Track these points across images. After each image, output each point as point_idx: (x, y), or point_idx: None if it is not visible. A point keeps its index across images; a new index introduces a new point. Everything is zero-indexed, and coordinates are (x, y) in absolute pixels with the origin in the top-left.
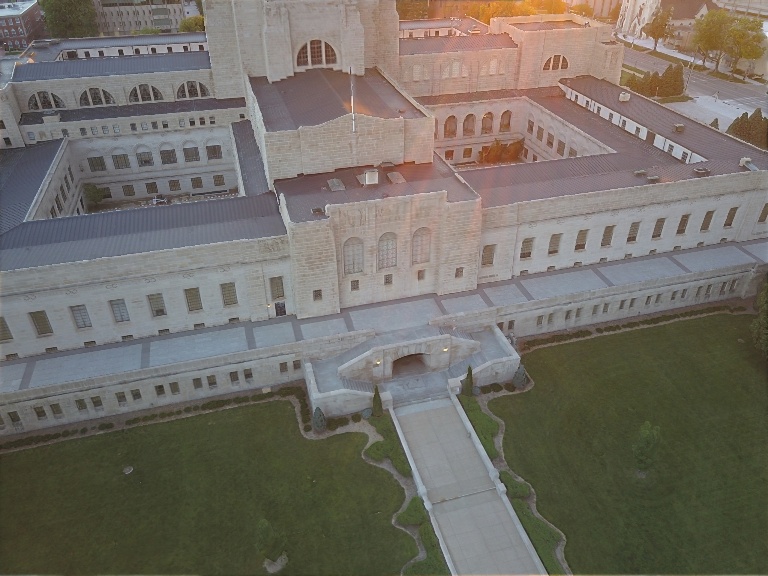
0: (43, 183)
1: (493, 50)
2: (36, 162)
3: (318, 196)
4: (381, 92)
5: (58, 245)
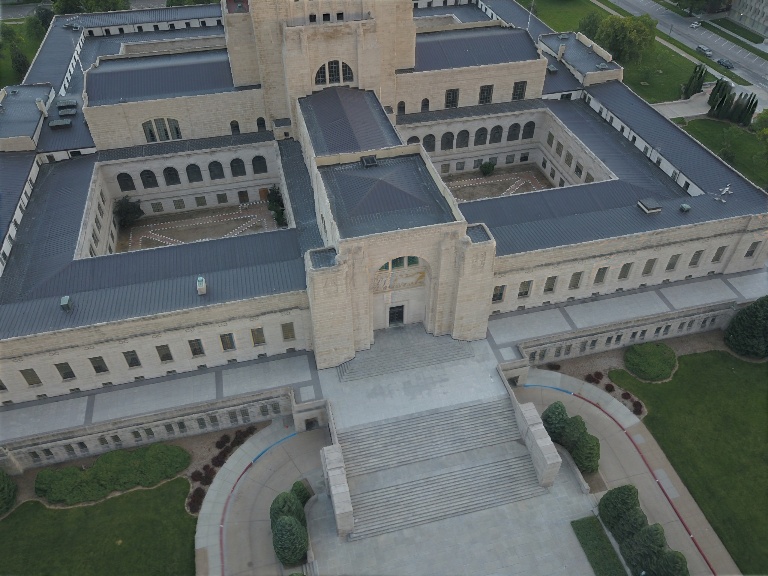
0: (173, 39)
1: (313, 155)
2: (215, 33)
3: (42, 94)
4: (183, 94)
5: (70, 50)
